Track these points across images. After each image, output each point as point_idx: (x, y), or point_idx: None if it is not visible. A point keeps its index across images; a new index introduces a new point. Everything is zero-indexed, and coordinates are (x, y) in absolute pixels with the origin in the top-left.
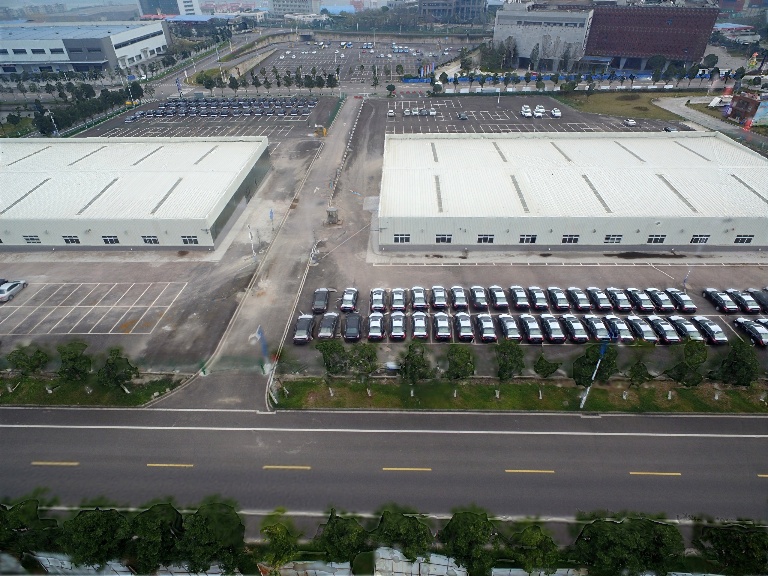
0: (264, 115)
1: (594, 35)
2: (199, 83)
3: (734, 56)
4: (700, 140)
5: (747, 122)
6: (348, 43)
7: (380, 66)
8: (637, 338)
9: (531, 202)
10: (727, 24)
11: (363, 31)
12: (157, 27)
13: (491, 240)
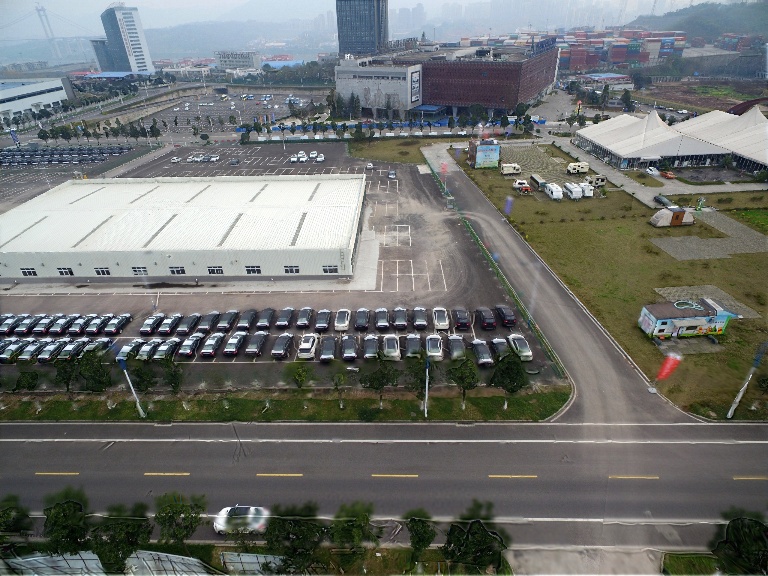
0: (62, 163)
1: (426, 87)
2: None
3: (574, 104)
4: (343, 182)
5: (474, 165)
6: (249, 95)
7: None
8: (15, 357)
9: (90, 239)
10: (609, 74)
11: None
12: (56, 84)
13: (35, 273)
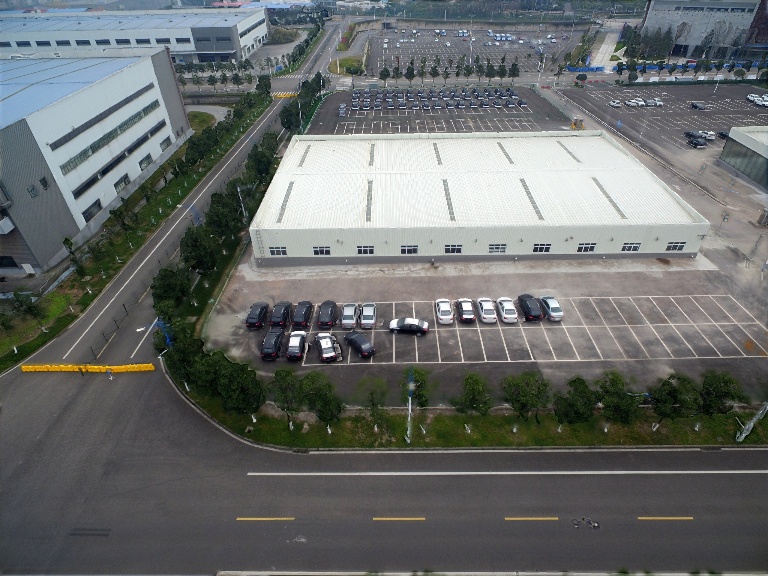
0: (478, 107)
1: None
2: (351, 73)
3: None
4: None
5: None
6: (442, 31)
7: (499, 54)
8: None
9: None
10: None
11: (448, 18)
12: (261, 15)
13: None
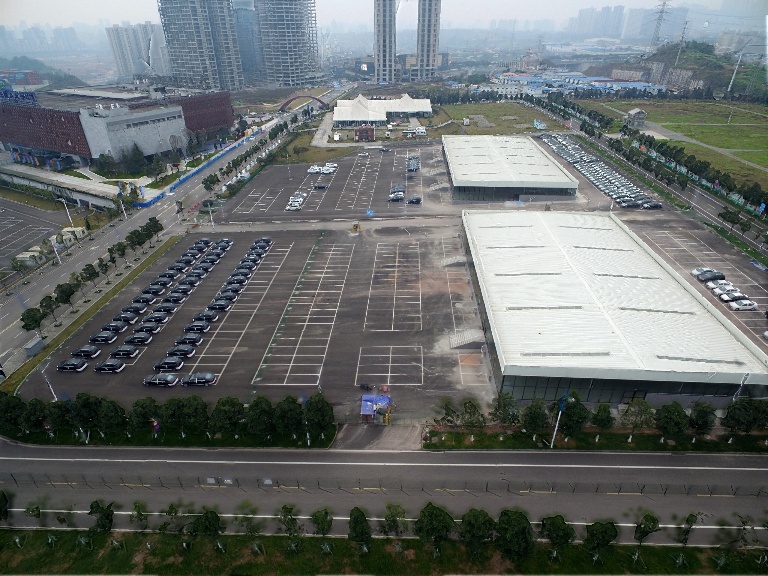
0: None
1: None
2: None
3: None
4: (449, 139)
5: (372, 139)
6: None
7: None
8: None
9: None
10: None
11: None
12: None
13: None
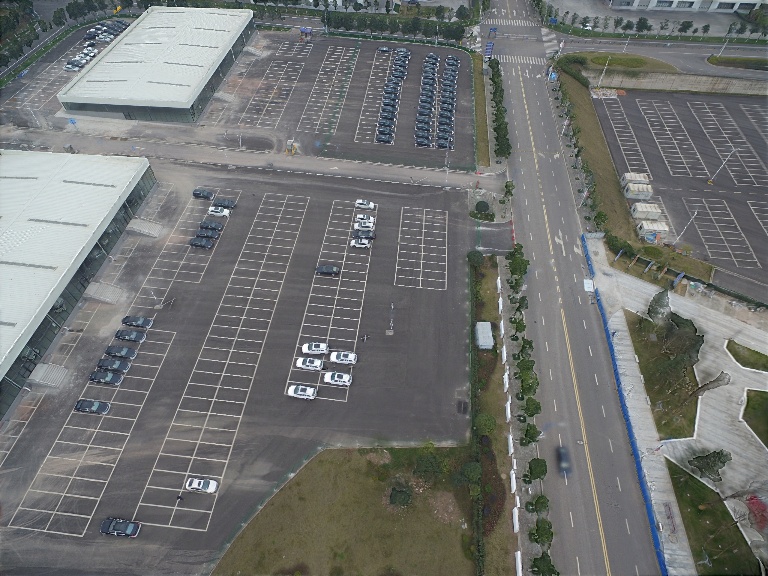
0: None
1: None
2: None
3: None
4: None
5: None
6: None
7: None
8: None
9: None
10: None
11: None
12: None
13: None
